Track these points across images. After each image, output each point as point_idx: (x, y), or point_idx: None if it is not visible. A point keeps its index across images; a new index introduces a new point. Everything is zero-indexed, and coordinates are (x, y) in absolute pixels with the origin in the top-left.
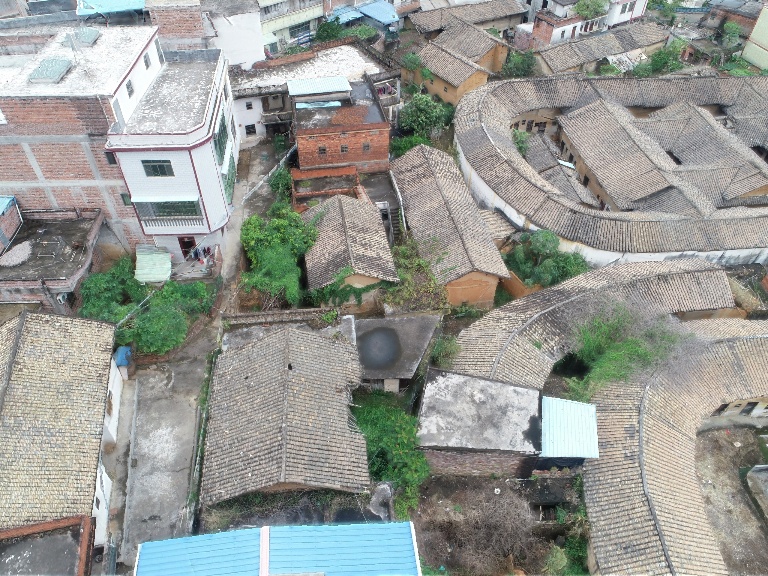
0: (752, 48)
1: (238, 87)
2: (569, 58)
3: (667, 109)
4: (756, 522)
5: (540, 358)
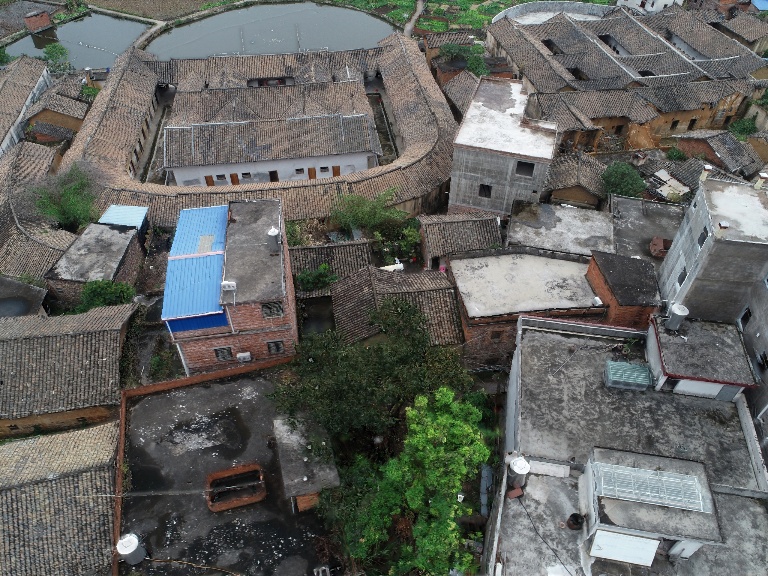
0: None
1: None
2: None
3: None
4: None
5: (58, 233)
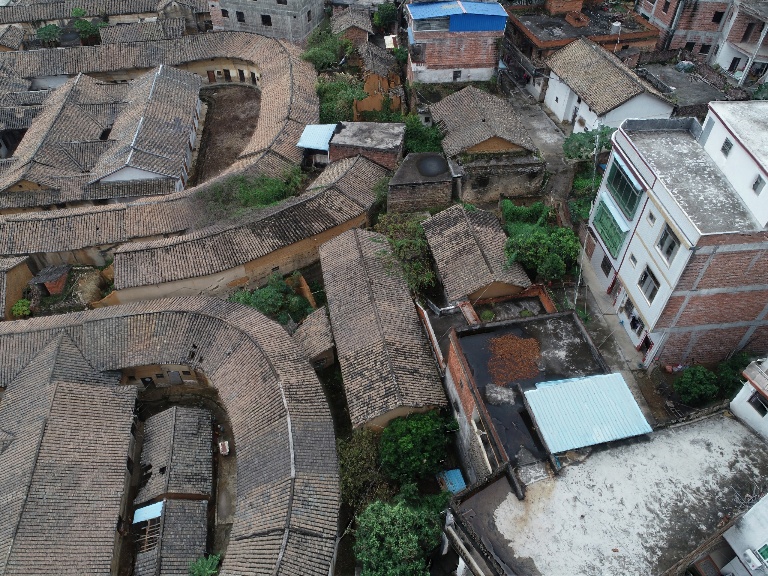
0: None
1: (739, 443)
2: None
3: None
4: None
5: None
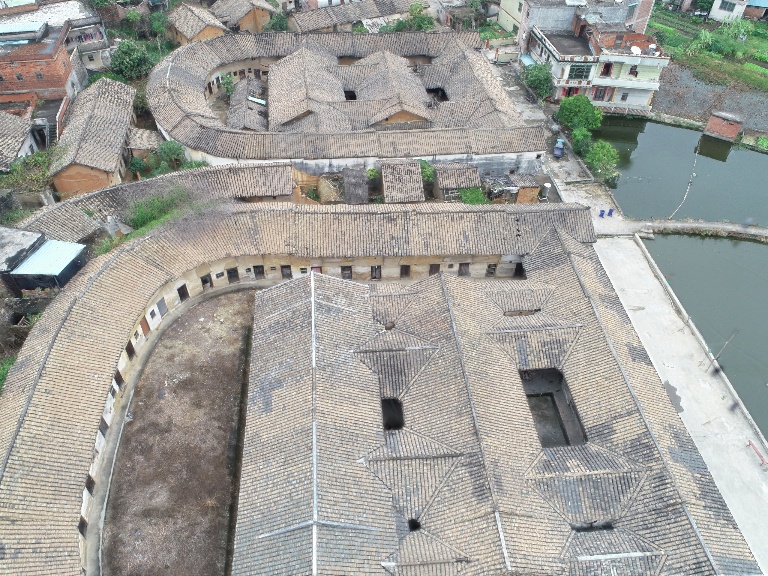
0: (502, 13)
1: None
2: (322, 20)
3: (367, 57)
4: (239, 345)
5: (86, 222)
